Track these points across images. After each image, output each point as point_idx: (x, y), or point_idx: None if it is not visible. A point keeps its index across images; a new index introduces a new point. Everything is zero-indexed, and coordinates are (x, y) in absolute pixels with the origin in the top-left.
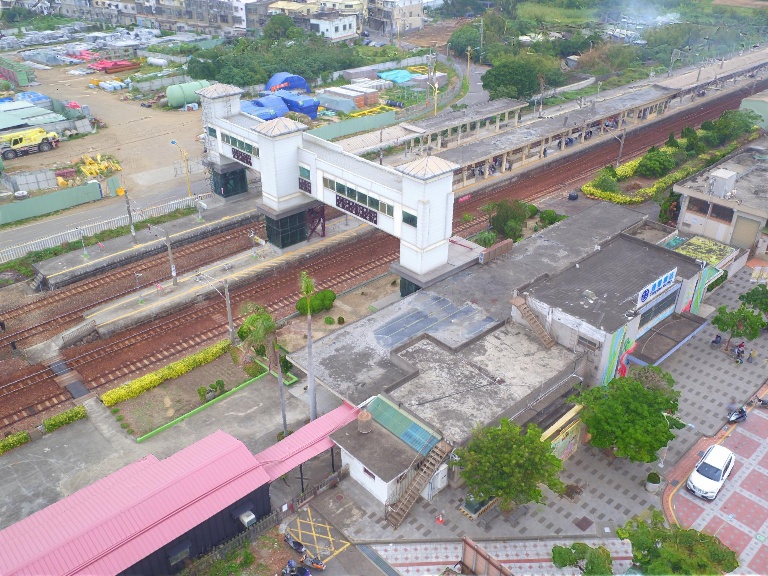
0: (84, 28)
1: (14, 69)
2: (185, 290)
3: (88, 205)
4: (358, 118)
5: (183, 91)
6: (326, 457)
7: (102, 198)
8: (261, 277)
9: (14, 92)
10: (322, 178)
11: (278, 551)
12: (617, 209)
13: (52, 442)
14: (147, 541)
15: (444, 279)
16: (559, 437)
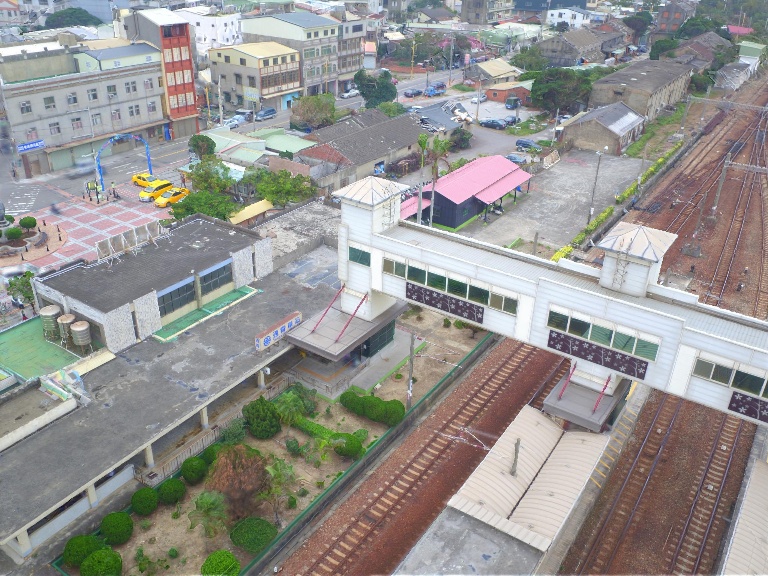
0: None
1: None
2: None
3: None
4: None
5: None
6: None
7: None
8: None
9: None
10: None
11: None
12: None
13: None
14: None
15: None
16: None
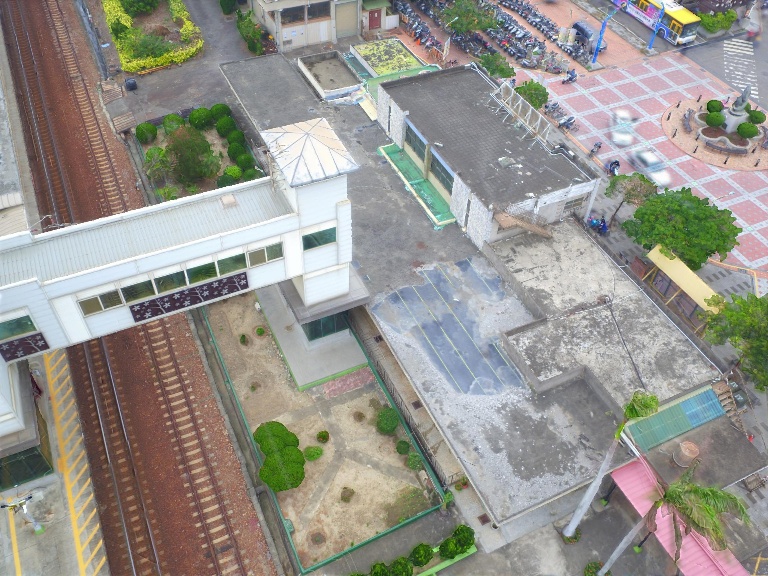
0: None
1: None
2: None
3: None
4: None
5: None
6: (641, 532)
7: None
8: None
9: None
10: (76, 306)
11: None
12: (250, 66)
13: None
14: None
15: None
16: None
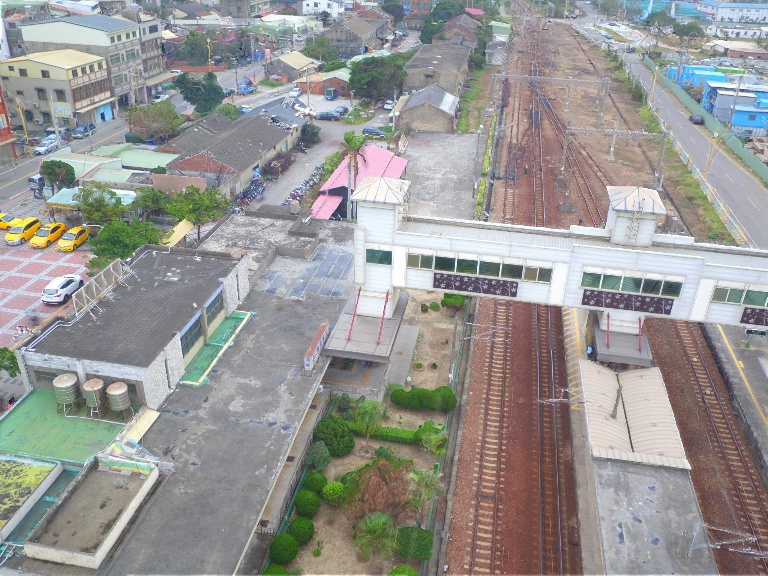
0: None
1: None
2: None
3: None
4: None
5: None
6: None
7: None
8: None
9: None
10: None
11: None
12: None
13: (466, 210)
14: (340, 169)
15: None
16: None
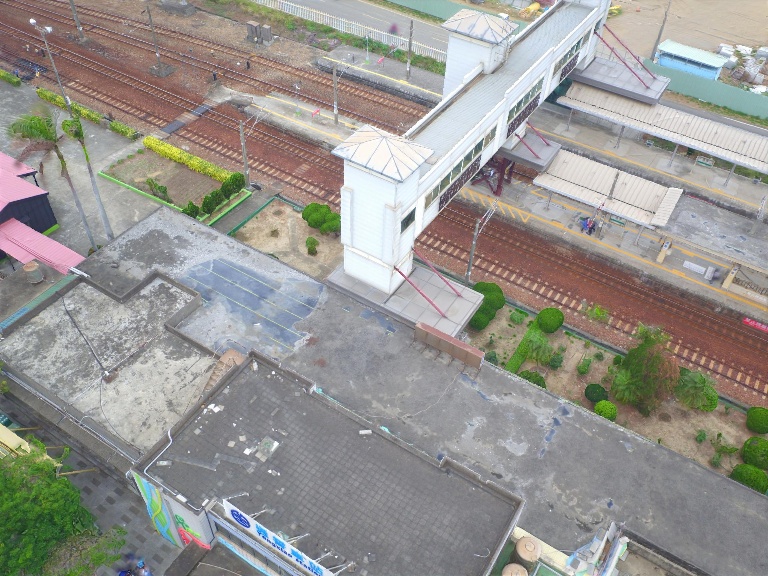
0: None
1: None
2: (329, 131)
3: None
4: None
5: None
6: None
7: None
8: None
9: None
10: None
11: None
12: None
13: (101, 135)
14: None
15: None
16: None
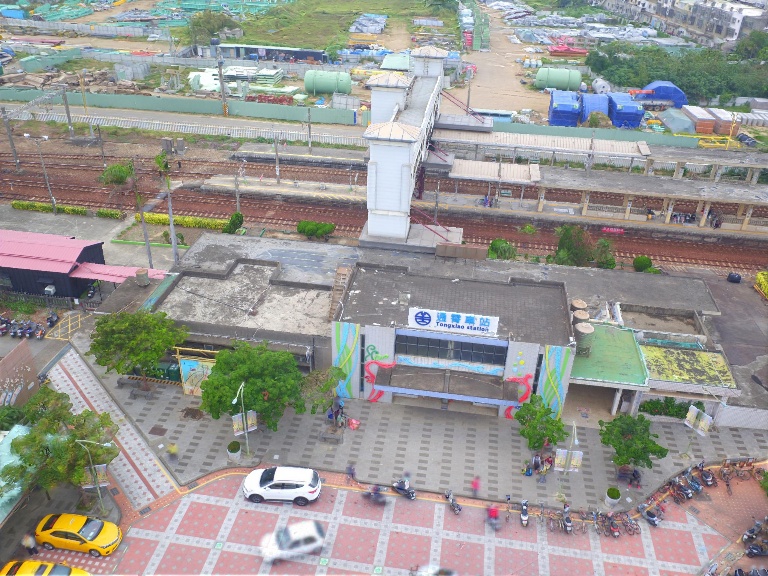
0: (603, 20)
1: (478, 36)
2: (277, 188)
3: (341, 126)
4: (642, 132)
5: (548, 75)
6: None
7: (355, 125)
8: (337, 205)
9: (460, 52)
10: None
11: (46, 318)
12: (696, 291)
13: (92, 221)
14: None
15: (389, 250)
16: (197, 358)
